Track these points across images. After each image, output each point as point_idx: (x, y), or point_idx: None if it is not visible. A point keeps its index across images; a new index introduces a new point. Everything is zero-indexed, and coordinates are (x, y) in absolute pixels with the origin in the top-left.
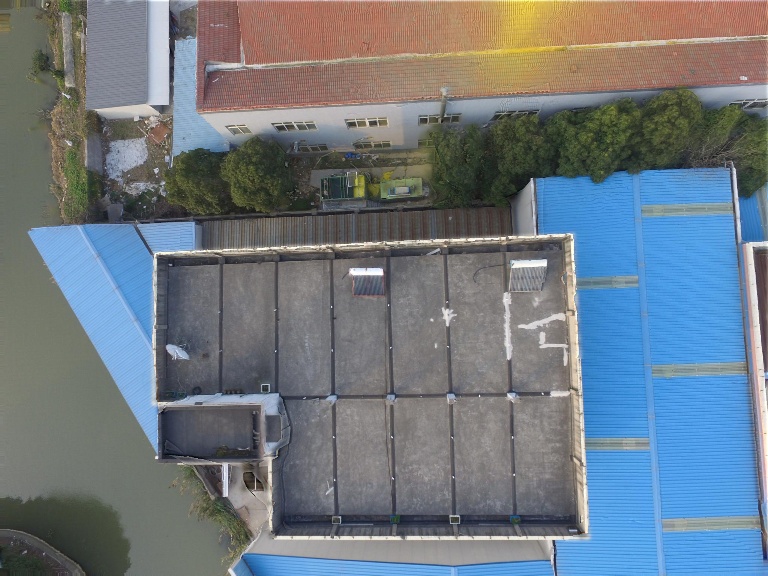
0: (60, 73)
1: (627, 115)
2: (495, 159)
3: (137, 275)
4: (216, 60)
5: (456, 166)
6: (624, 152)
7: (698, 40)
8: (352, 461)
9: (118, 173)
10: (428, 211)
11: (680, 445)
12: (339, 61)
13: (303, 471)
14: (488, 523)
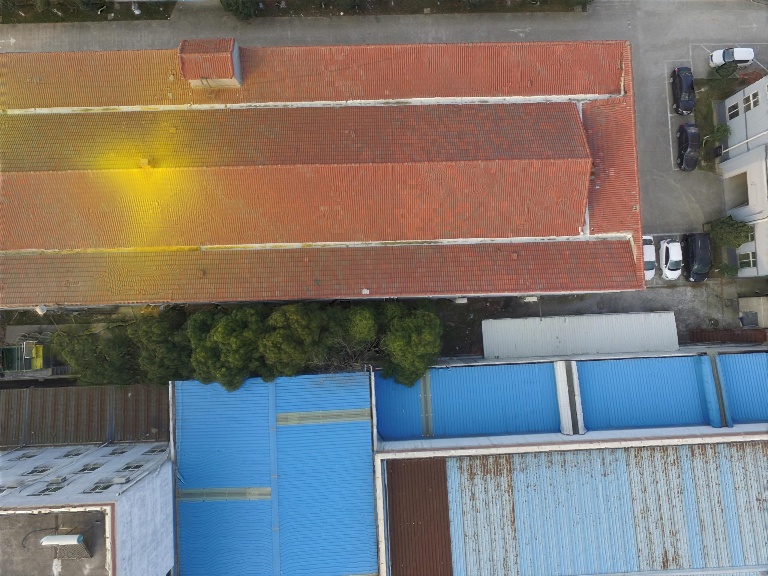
0: None
1: (238, 335)
2: None
3: None
4: None
5: (91, 367)
6: (251, 363)
7: (333, 243)
8: None
9: None
10: (107, 386)
11: None
12: None
13: None
14: None
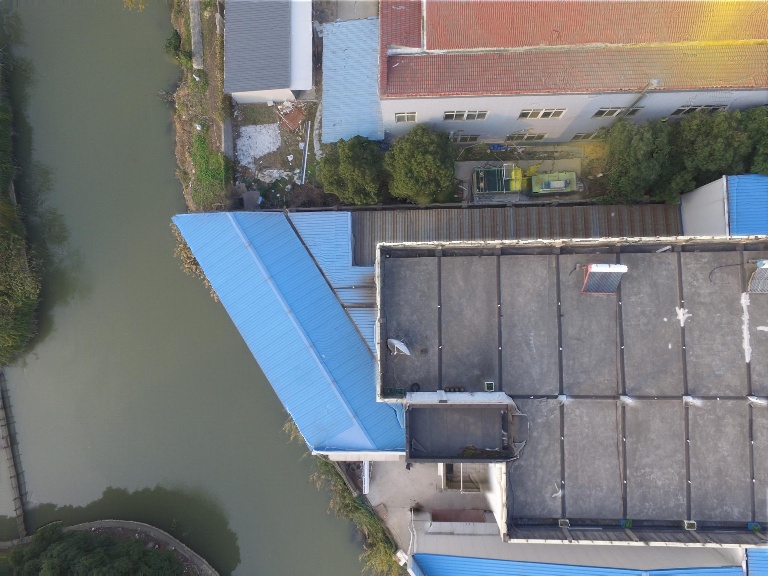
0: (188, 54)
1: None
2: (681, 155)
3: (289, 265)
4: (398, 44)
5: (644, 161)
6: None
7: None
8: (581, 463)
9: (249, 159)
10: (589, 206)
11: None
12: (525, 49)
13: (529, 472)
14: (727, 529)
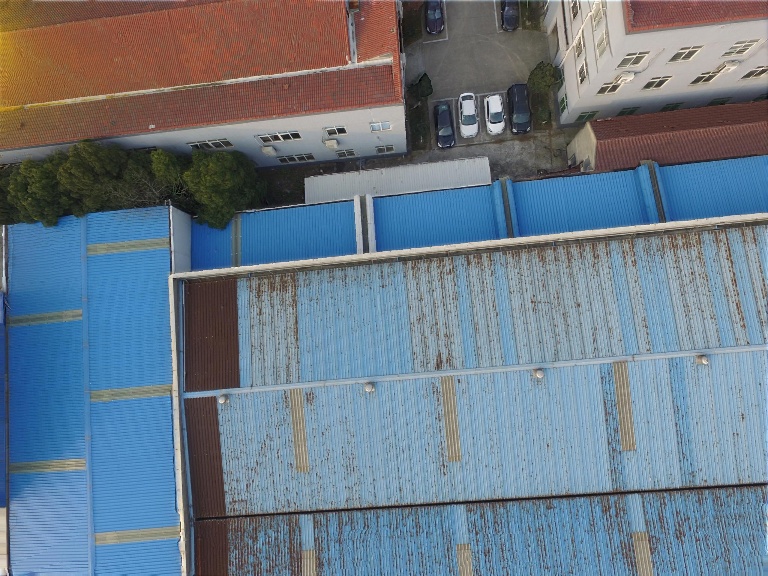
0: None
1: (39, 168)
2: None
3: None
4: None
5: None
6: (61, 199)
7: (132, 93)
8: None
9: None
10: None
11: (114, 463)
12: None
13: None
14: None
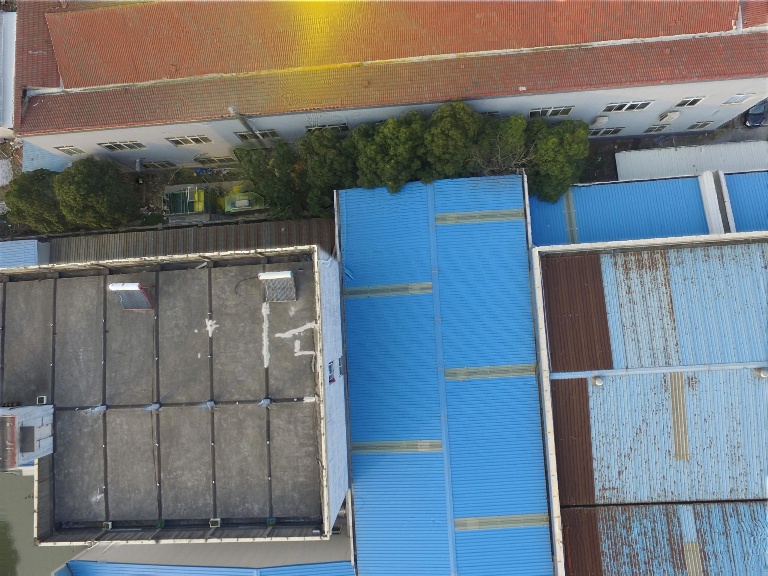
0: None
1: (406, 128)
2: (305, 172)
3: None
4: (34, 85)
5: (264, 180)
6: (414, 163)
7: (486, 53)
8: (121, 468)
9: None
10: (262, 223)
11: (472, 446)
12: (152, 83)
13: (76, 479)
14: None
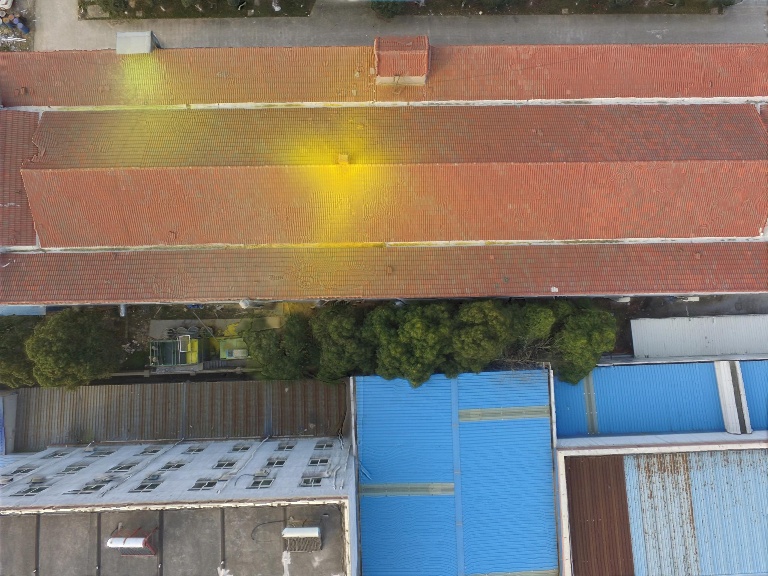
0: None
1: (435, 331)
2: (317, 350)
3: None
4: (5, 244)
5: (273, 362)
6: (439, 359)
7: (516, 241)
8: None
9: None
10: (264, 381)
11: None
12: (146, 247)
13: None
14: None
